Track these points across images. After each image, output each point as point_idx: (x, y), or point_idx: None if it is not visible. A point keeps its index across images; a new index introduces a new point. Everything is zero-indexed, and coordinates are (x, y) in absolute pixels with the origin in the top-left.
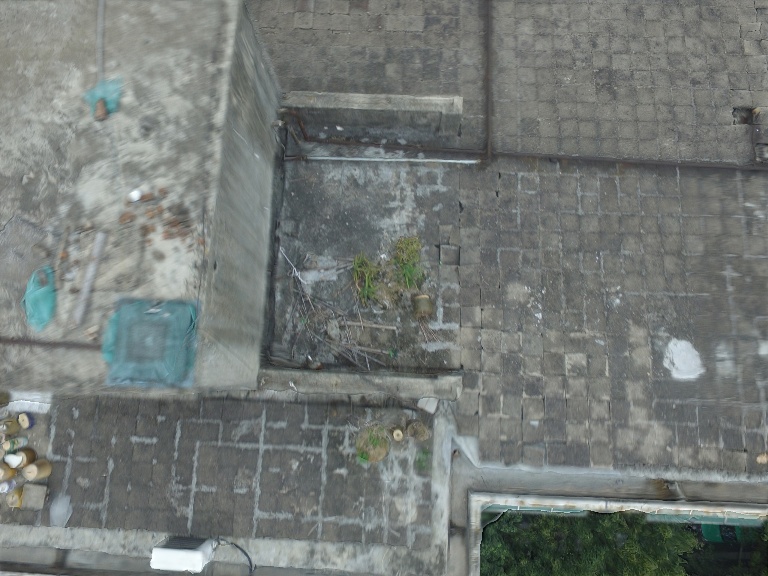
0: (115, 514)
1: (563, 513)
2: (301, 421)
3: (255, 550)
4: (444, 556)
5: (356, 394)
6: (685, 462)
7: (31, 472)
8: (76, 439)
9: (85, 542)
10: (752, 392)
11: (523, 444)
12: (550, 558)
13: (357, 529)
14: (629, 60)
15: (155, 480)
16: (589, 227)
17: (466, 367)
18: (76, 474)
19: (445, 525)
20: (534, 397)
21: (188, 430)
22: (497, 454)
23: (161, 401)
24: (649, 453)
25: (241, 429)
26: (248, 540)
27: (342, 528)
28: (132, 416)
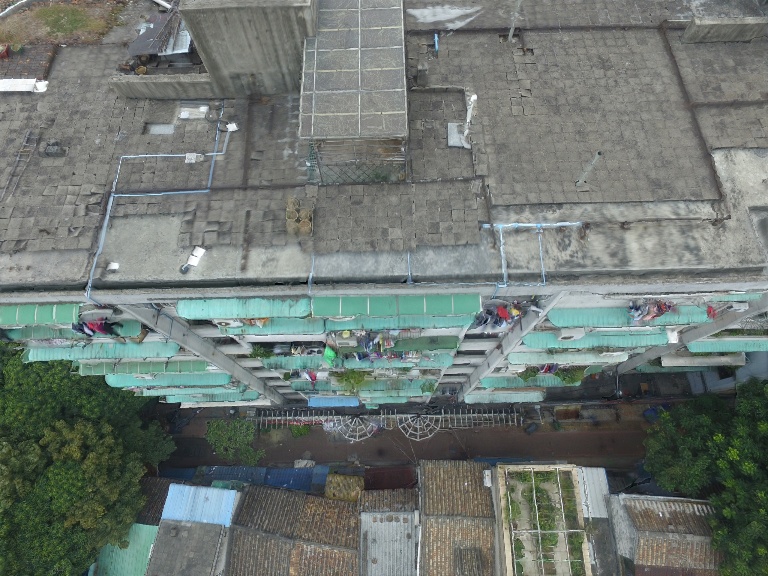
0: None
1: None
2: None
3: None
4: None
5: None
6: None
7: None
8: None
9: None
10: None
11: None
12: None
13: None
14: (595, 75)
15: None
16: (601, 5)
17: None
18: None
19: None
20: None
21: None
22: None
23: None
24: None
25: None
26: None
27: None
28: None
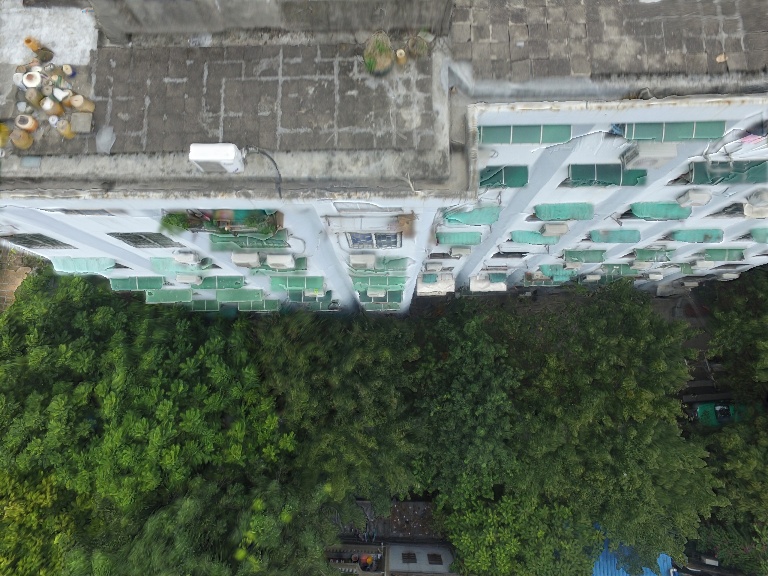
0: (154, 138)
1: (563, 366)
2: (314, 56)
3: (280, 165)
4: (447, 158)
5: (362, 8)
6: (654, 67)
7: (78, 100)
8: (115, 83)
9: (128, 169)
10: (710, 8)
11: (511, 62)
12: (553, 408)
13: (369, 136)
14: None
15: (188, 110)
16: None
17: (458, 4)
18: (117, 110)
19: (446, 135)
20: (519, 24)
21: (214, 70)
22: (489, 70)
23: (189, 48)
24: (622, 61)
25: (261, 65)
26: (273, 154)
27: (356, 136)
28: (164, 62)
